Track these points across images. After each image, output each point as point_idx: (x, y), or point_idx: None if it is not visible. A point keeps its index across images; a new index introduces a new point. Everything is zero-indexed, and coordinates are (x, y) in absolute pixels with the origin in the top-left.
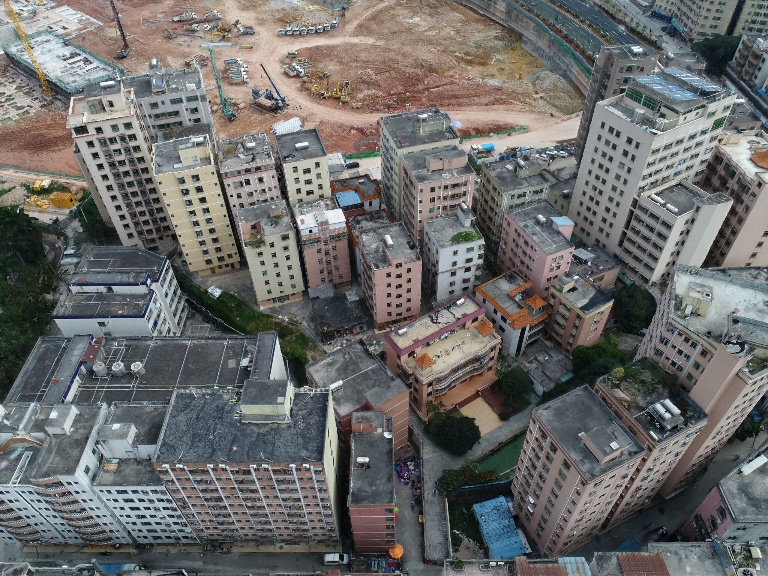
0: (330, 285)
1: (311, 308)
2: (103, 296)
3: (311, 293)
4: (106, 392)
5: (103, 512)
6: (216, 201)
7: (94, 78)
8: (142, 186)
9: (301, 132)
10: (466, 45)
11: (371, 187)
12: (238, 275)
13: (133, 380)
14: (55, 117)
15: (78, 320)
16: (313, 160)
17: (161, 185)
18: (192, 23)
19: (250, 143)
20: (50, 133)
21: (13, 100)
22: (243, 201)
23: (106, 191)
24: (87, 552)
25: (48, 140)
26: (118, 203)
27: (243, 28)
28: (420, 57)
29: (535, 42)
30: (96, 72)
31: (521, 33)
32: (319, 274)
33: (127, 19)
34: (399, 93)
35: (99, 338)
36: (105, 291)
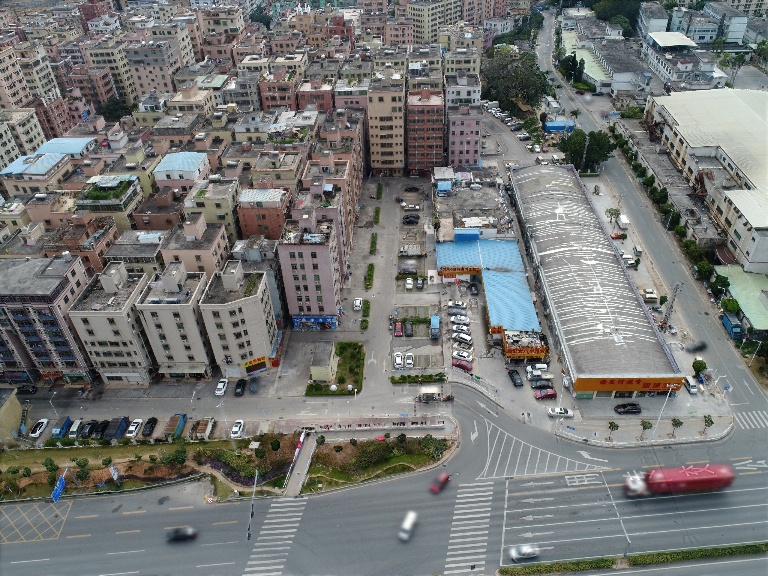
0: None
1: None
2: None
3: None
4: None
5: None
6: None
7: None
8: None
9: None
10: None
11: None
12: None
13: None
14: None
15: None
16: None
17: None
18: None
19: None
20: None
21: None
22: None
23: None
24: None
25: None
26: None
27: None
28: None
29: (31, 1)
30: None
31: (17, 3)
32: None
33: None
34: None
35: None
36: None
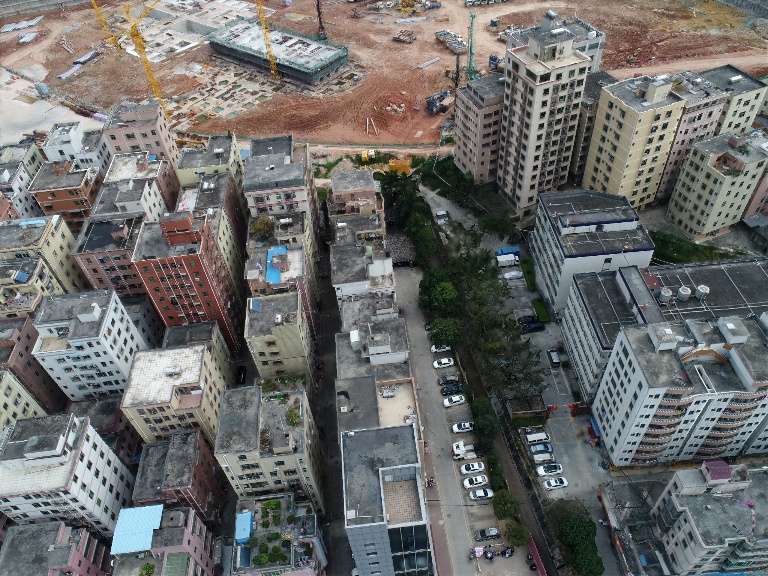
0: (761, 215)
1: (745, 238)
2: (595, 235)
3: (749, 223)
4: (683, 315)
5: (761, 418)
6: (668, 138)
7: (327, 57)
8: (564, 134)
9: (716, 69)
10: (659, 1)
11: (762, 121)
12: (648, 216)
13: (700, 303)
14: (296, 98)
15: (588, 258)
16: (757, 91)
17: (639, 123)
18: (369, 2)
19: (696, 79)
20: (302, 113)
21: (241, 86)
22: (686, 137)
23: (535, 141)
24: (675, 471)
25: (307, 120)
26: (538, 153)
27: (430, 2)
28: (624, 15)
29: None
30: (322, 52)
31: None
32: (758, 203)
33: (299, 4)
34: (628, 49)
35: (639, 269)
36: (595, 230)
